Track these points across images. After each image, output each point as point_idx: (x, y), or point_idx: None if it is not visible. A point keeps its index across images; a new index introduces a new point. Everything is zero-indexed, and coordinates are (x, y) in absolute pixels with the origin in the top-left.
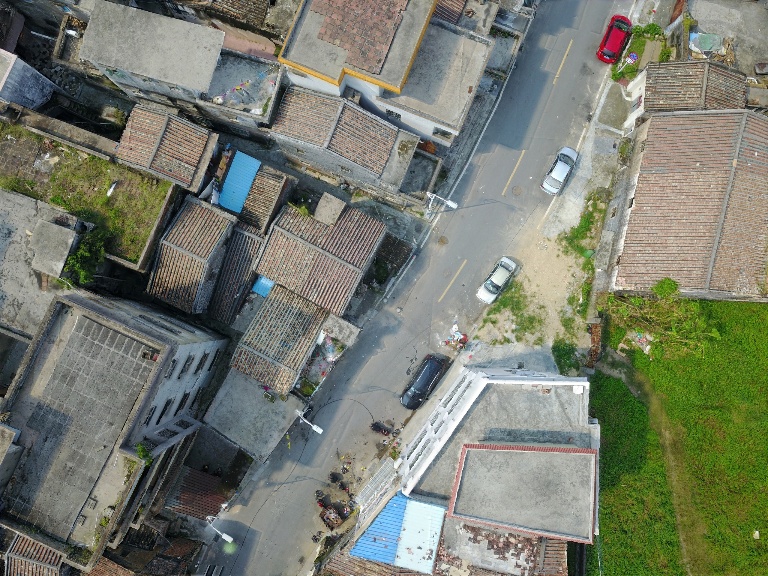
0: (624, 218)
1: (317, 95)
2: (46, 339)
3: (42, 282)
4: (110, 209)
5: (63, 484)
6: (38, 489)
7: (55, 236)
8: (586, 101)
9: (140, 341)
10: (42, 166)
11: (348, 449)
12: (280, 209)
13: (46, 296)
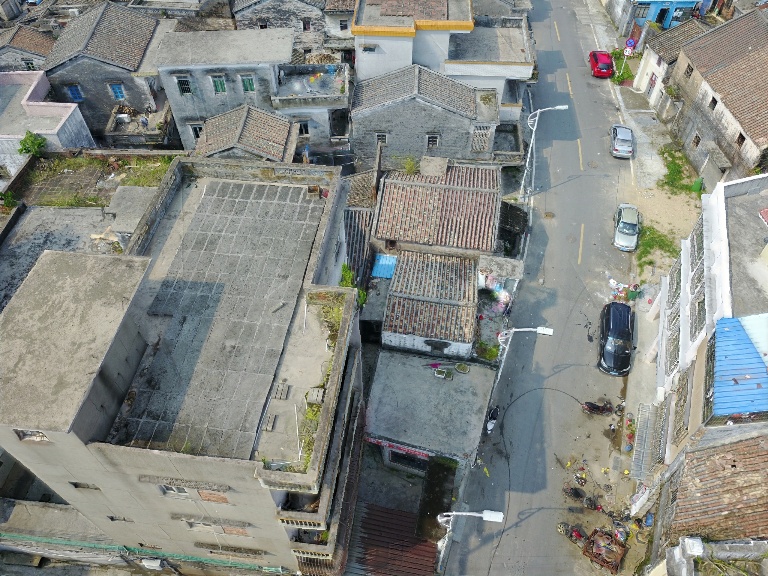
0: (715, 119)
1: (388, 75)
2: (164, 217)
3: None
4: None
5: (225, 372)
6: (181, 392)
7: (140, 196)
8: (607, 101)
9: None
10: (106, 184)
11: (569, 451)
12: (383, 173)
13: None
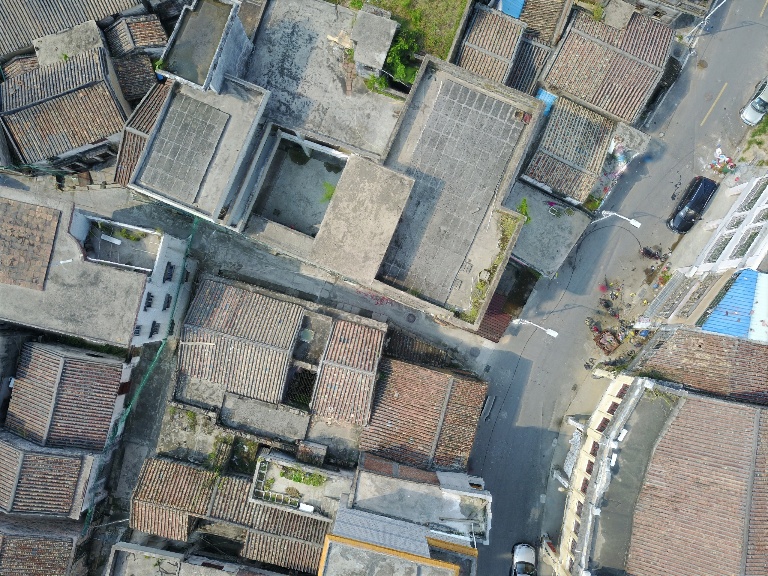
0: None
1: None
2: (410, 105)
3: (346, 87)
4: (413, 10)
5: (438, 248)
6: (413, 253)
7: (377, 27)
8: None
9: (507, 104)
10: None
11: (616, 276)
12: (572, 14)
13: (351, 101)
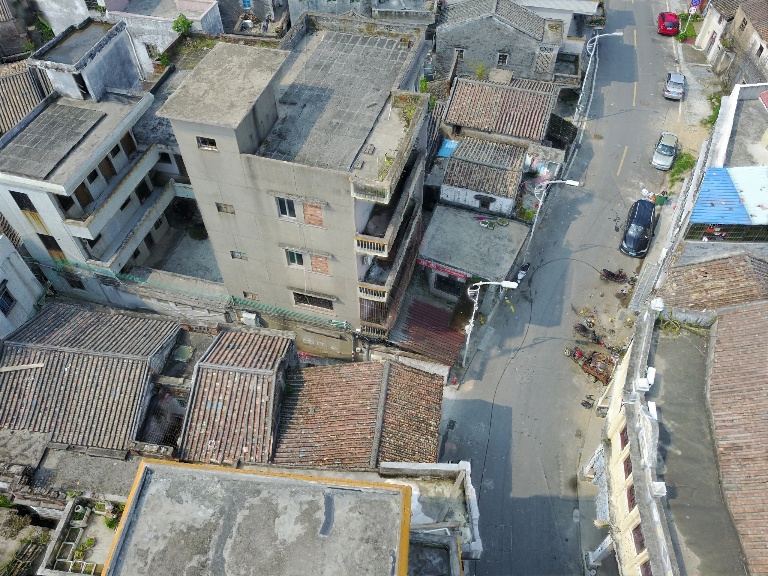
0: (760, 64)
1: (471, 0)
2: (292, 51)
3: None
4: None
5: (331, 135)
6: (300, 142)
7: None
8: (668, 54)
9: None
10: None
11: (584, 303)
12: None
13: None
